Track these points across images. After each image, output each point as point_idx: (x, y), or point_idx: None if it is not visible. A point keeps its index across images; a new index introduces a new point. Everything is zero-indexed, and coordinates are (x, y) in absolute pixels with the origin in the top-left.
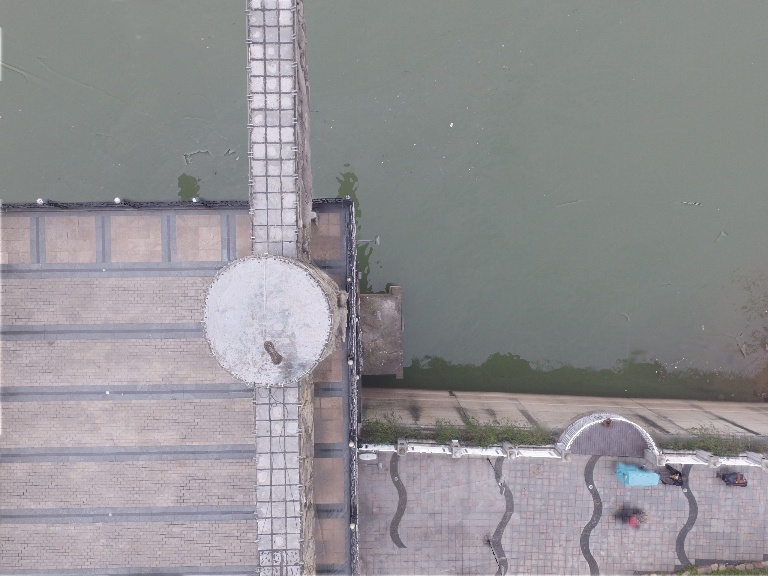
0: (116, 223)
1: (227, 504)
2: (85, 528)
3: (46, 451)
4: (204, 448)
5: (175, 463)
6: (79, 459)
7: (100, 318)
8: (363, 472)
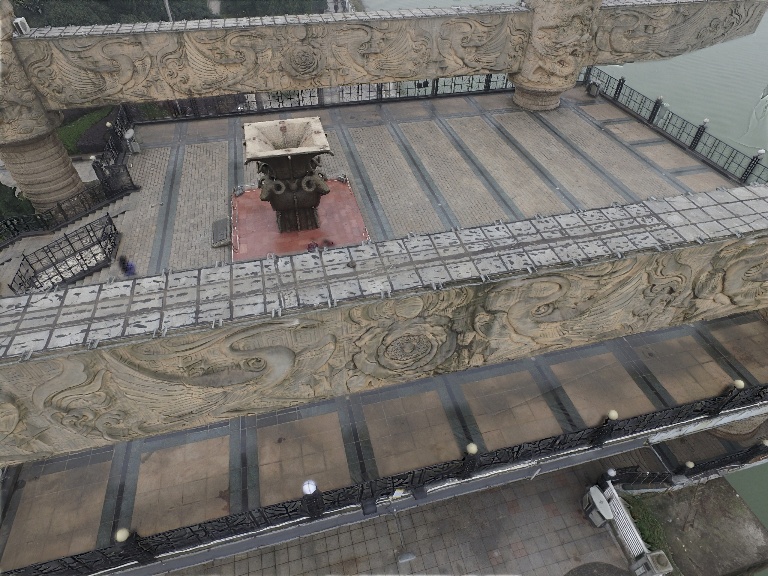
0: (711, 175)
1: None
2: (419, 192)
3: (479, 164)
4: None
5: None
6: (483, 181)
7: (620, 177)
8: (551, 513)
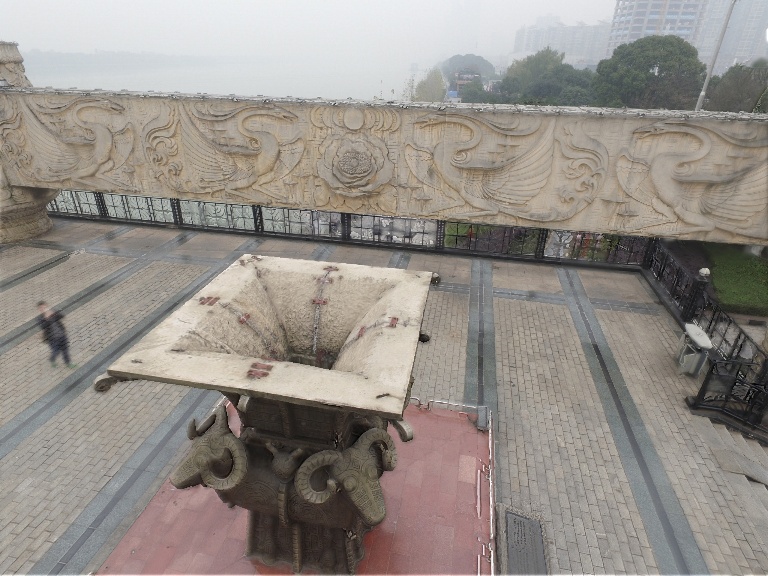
0: None
1: (160, 305)
2: None
3: None
4: (50, 312)
5: (26, 343)
6: None
7: None
8: None
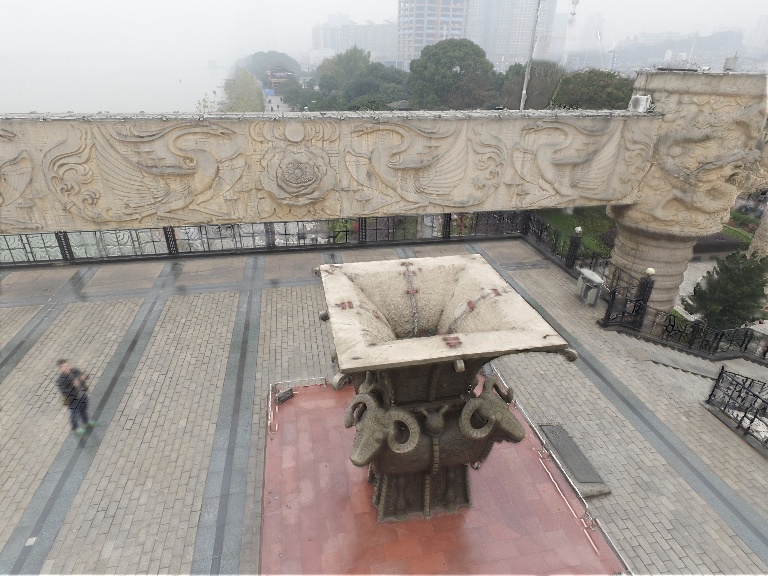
0: None
1: (116, 347)
2: None
3: None
4: None
5: None
6: None
7: None
8: None
